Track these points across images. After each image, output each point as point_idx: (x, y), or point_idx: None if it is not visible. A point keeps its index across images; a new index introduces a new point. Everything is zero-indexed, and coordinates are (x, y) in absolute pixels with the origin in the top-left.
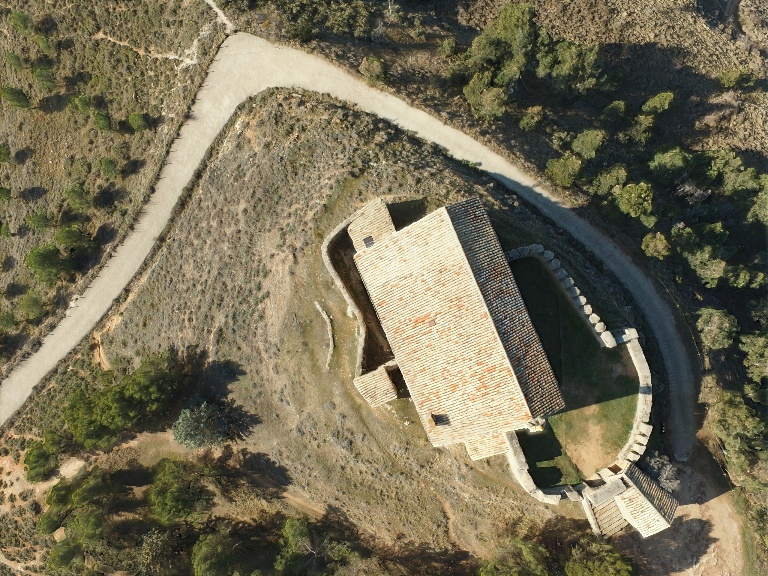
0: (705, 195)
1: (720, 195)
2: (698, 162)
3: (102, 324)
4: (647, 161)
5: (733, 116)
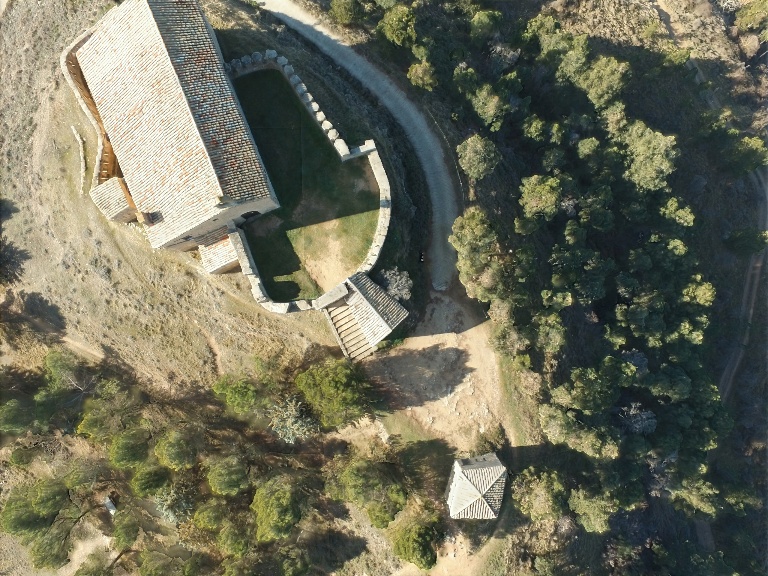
0: (516, 55)
1: (538, 61)
2: None
3: None
4: None
5: (582, 2)
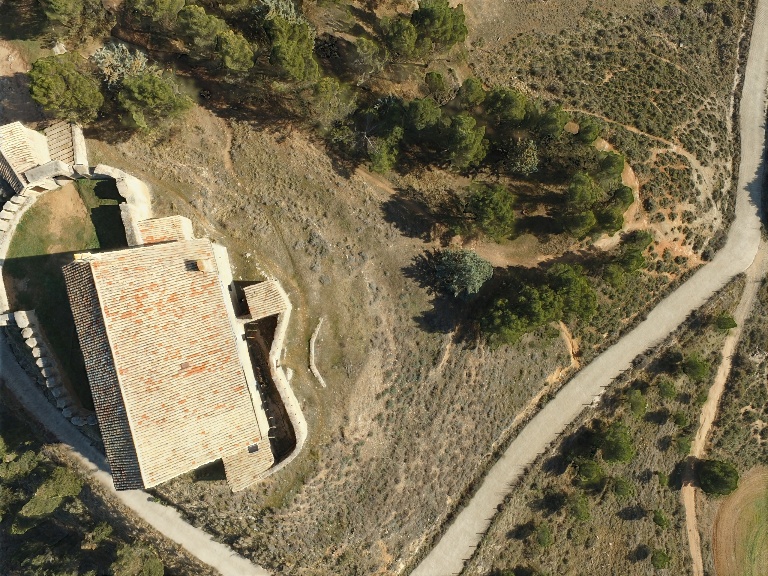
0: None
1: None
2: None
3: (569, 375)
4: None
5: None
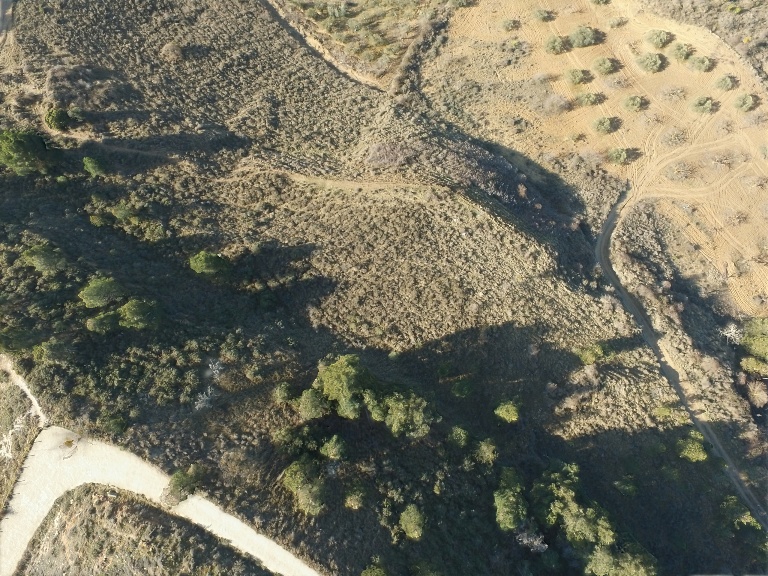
0: (543, 548)
1: (564, 533)
2: (541, 495)
3: None
4: (495, 486)
5: (594, 394)
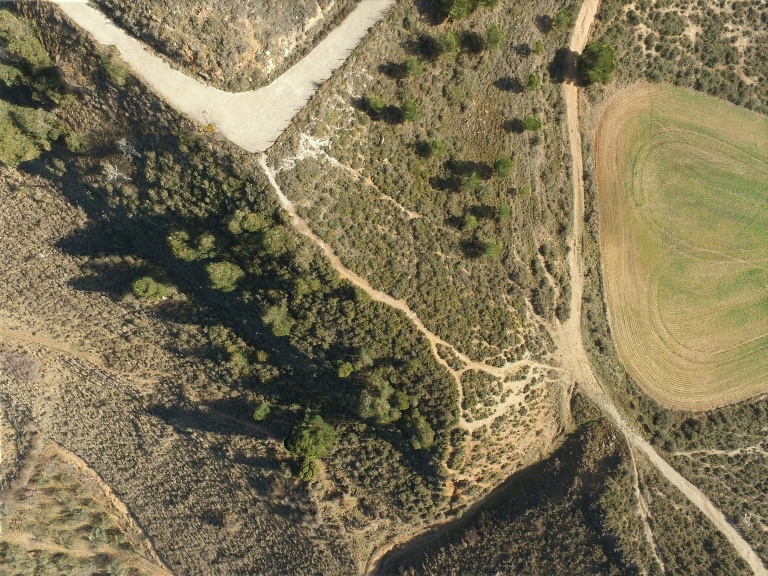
0: None
1: None
2: None
3: None
4: None
5: None
